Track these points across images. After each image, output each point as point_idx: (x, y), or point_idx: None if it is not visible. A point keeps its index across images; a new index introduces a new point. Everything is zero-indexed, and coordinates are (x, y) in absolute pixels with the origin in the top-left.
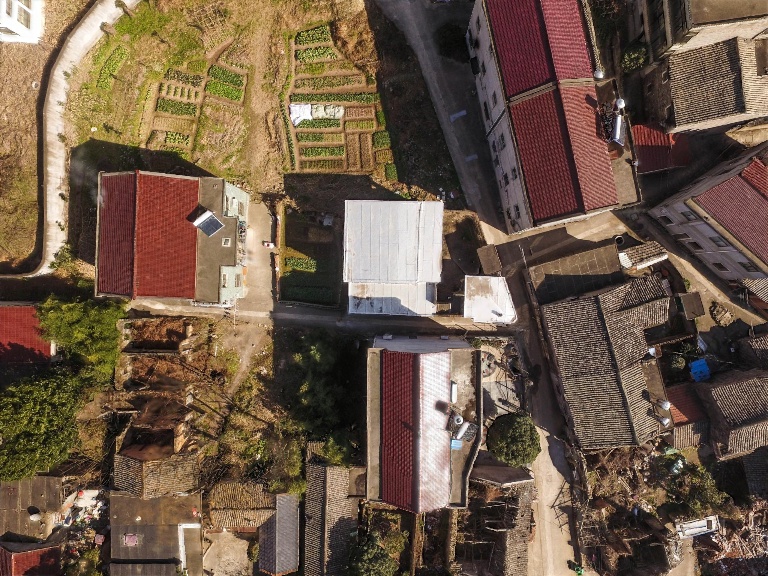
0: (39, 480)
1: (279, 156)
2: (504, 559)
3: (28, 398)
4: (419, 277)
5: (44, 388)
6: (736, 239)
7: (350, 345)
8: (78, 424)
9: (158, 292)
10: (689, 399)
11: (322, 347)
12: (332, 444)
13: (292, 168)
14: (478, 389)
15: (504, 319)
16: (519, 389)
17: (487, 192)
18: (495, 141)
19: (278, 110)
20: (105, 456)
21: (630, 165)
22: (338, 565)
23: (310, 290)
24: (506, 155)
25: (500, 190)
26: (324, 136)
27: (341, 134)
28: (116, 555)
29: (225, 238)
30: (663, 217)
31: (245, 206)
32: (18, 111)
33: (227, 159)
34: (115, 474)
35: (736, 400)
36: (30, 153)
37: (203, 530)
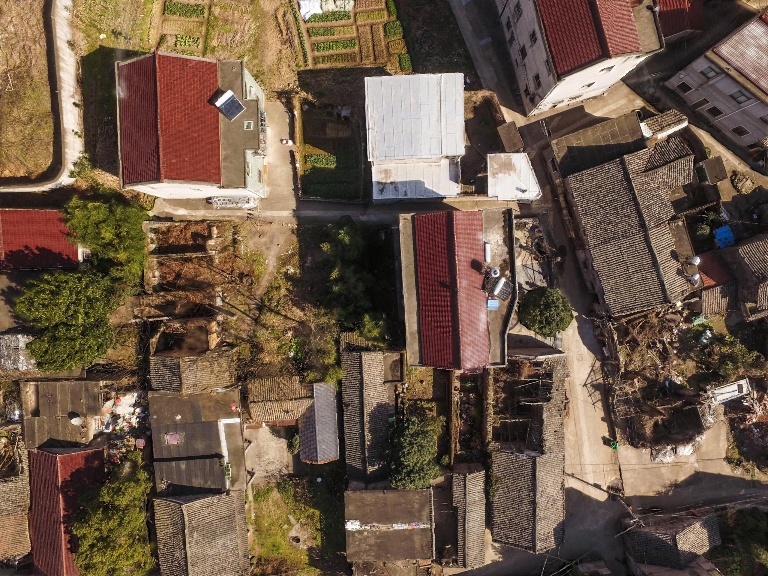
0: (77, 385)
1: (291, 53)
2: (541, 432)
3: (64, 286)
4: (443, 150)
5: (78, 280)
6: (758, 88)
7: (376, 235)
8: (111, 327)
9: (185, 176)
10: (715, 264)
11: (350, 230)
12: (368, 319)
13: (305, 64)
14: (511, 248)
15: (528, 195)
16: (545, 271)
17: (503, 75)
18: (510, 15)
19: (287, 6)
20: (140, 360)
21: (651, 11)
22: (378, 449)
23: (332, 186)
24: (523, 22)
25: (516, 70)
26: (335, 30)
27: (352, 26)
28: (159, 454)
29: (247, 121)
30: (681, 85)
31: (261, 103)
32: (25, 21)
33: (239, 59)
34: (151, 376)
35: (763, 255)
36: (40, 63)
37: (243, 425)
